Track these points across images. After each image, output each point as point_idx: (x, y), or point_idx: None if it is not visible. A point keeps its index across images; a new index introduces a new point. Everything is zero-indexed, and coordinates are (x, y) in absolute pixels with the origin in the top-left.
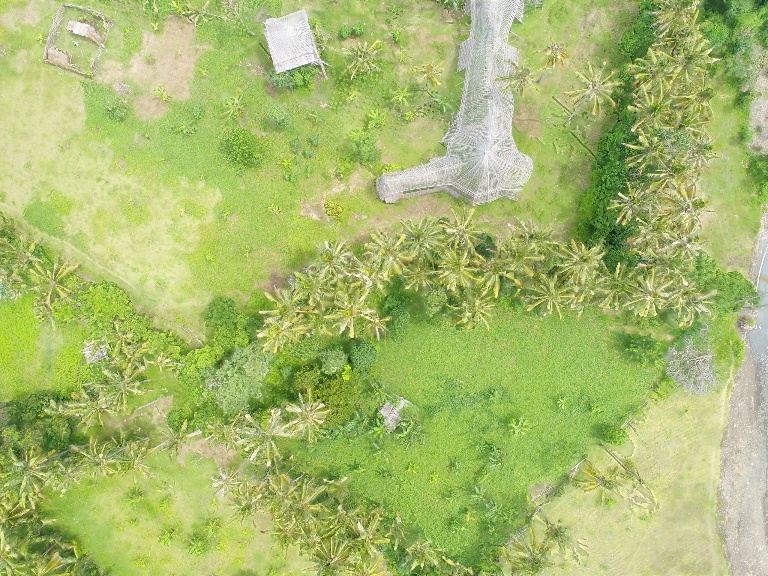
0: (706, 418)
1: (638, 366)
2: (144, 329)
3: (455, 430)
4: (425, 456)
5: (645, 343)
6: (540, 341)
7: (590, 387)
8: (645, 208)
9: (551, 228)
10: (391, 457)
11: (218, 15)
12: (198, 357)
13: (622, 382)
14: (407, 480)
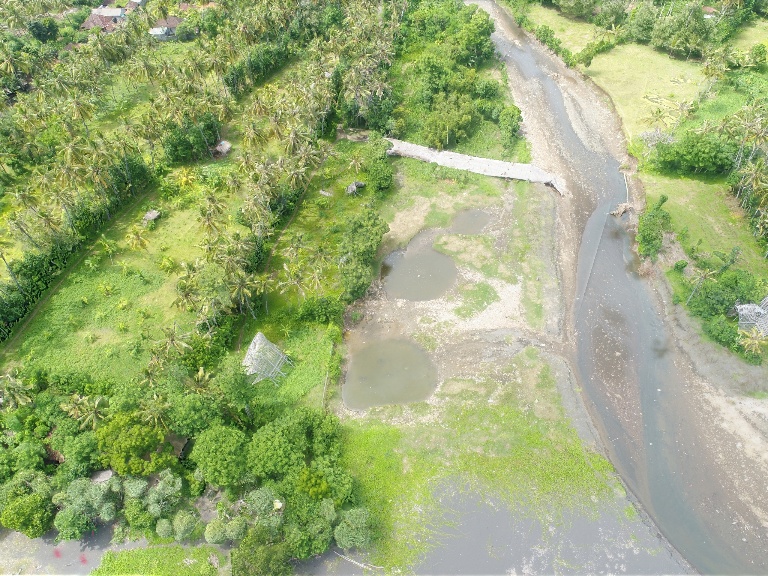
0: None
1: None
2: None
3: None
4: None
5: None
6: None
7: None
8: (764, 158)
9: None
10: None
11: None
12: None
13: None
14: None
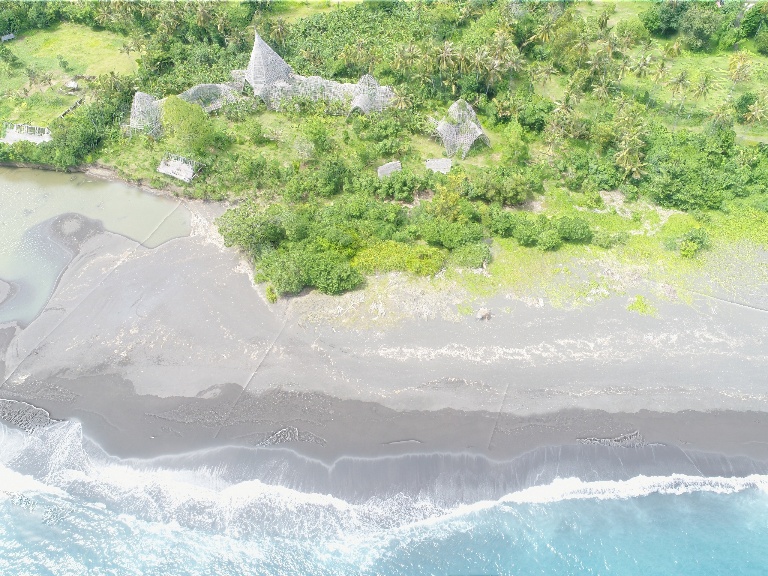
0: None
1: None
2: None
3: None
4: None
5: None
6: None
7: None
8: None
9: None
10: None
11: (3, 99)
12: (52, 5)
13: None
14: None
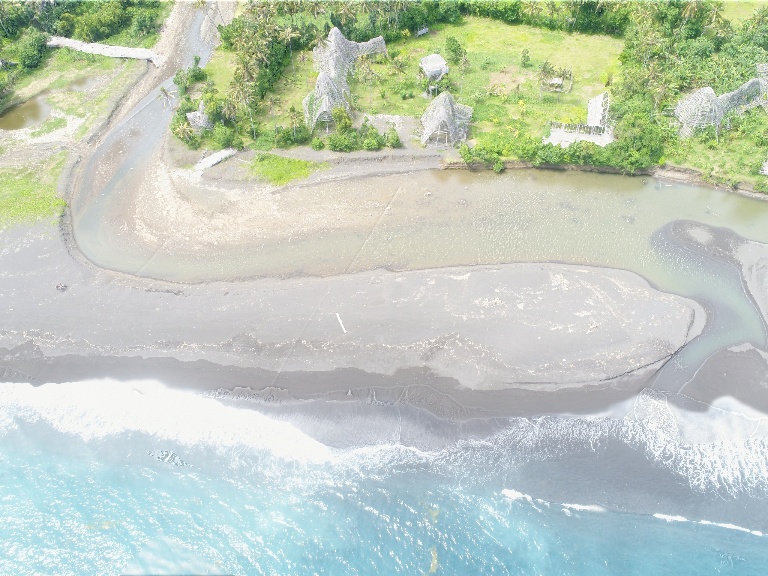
0: None
1: None
2: (487, 2)
3: None
4: None
5: None
6: None
7: None
8: None
9: None
10: None
11: None
12: None
13: None
14: None
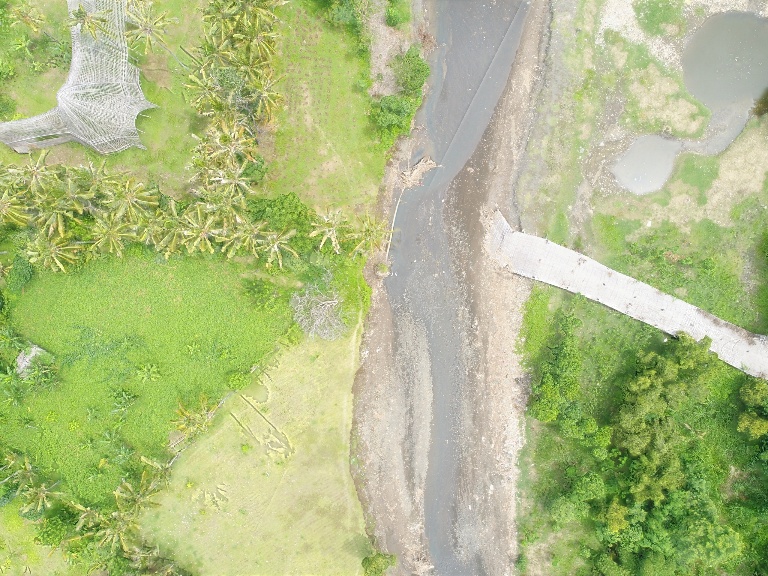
0: (337, 363)
1: (270, 312)
2: None
3: (94, 378)
4: (65, 404)
5: (254, 287)
6: (174, 289)
7: (223, 334)
8: None
9: (183, 177)
10: (33, 406)
11: None
12: None
13: (254, 328)
14: (48, 428)
